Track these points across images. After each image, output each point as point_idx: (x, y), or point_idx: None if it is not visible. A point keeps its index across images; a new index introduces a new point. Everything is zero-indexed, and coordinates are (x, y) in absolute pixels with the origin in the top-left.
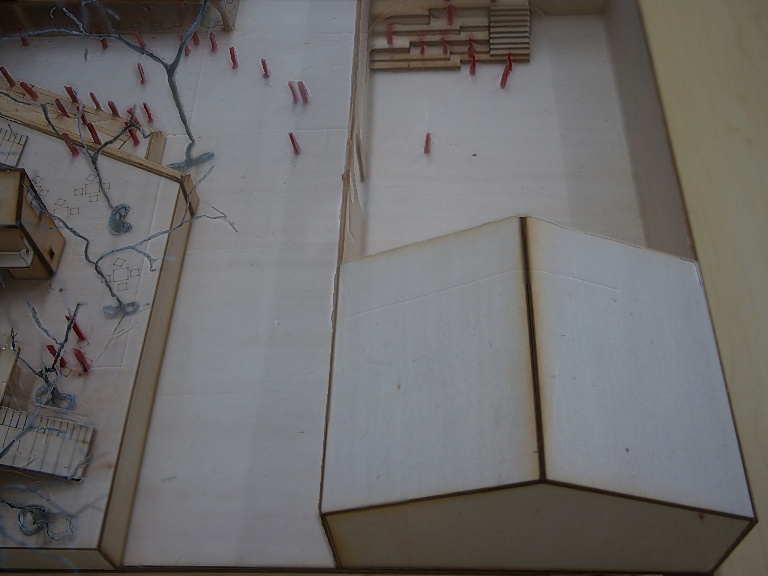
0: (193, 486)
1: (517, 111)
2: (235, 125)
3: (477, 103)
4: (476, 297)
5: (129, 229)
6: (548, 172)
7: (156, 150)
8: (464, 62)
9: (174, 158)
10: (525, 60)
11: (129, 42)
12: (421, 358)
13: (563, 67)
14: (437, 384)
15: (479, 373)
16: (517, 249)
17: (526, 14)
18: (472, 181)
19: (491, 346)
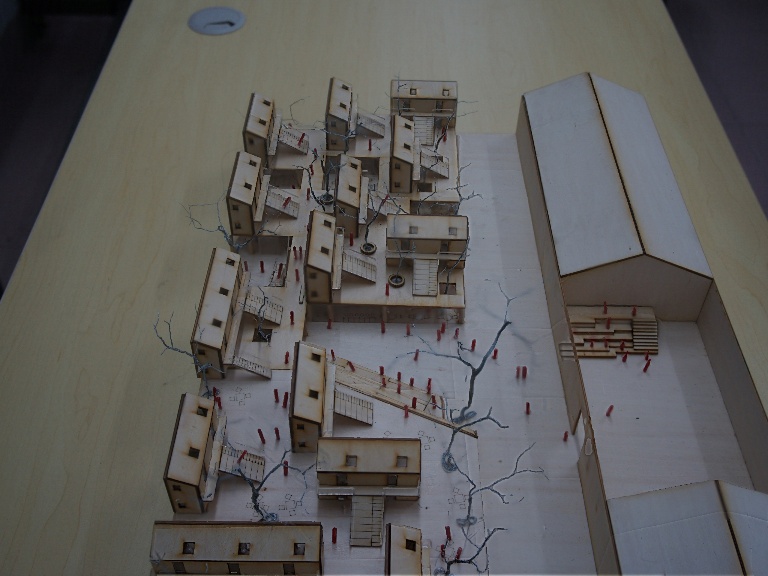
0: None
1: (657, 389)
2: (483, 392)
3: (631, 382)
4: (700, 526)
5: (456, 469)
6: (684, 431)
7: None
8: (618, 353)
9: None
10: (655, 353)
11: (398, 329)
12: (675, 559)
13: (679, 358)
14: (689, 574)
15: (712, 569)
16: (718, 499)
17: (655, 325)
18: (640, 436)
19: (715, 554)
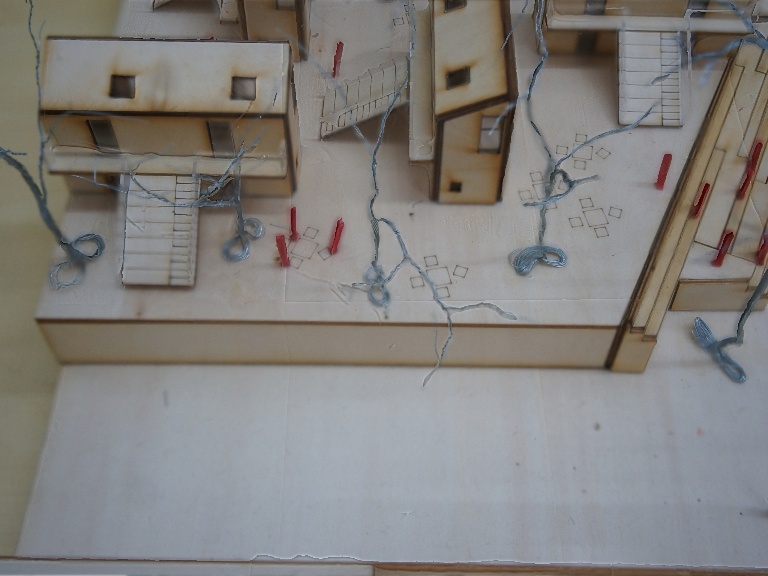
0: (151, 429)
1: None
2: None
3: None
4: None
5: (520, 272)
6: None
7: (717, 294)
8: None
9: (723, 327)
10: None
11: None
12: None
13: None
14: None
15: None
16: None
17: None
18: None
19: None
